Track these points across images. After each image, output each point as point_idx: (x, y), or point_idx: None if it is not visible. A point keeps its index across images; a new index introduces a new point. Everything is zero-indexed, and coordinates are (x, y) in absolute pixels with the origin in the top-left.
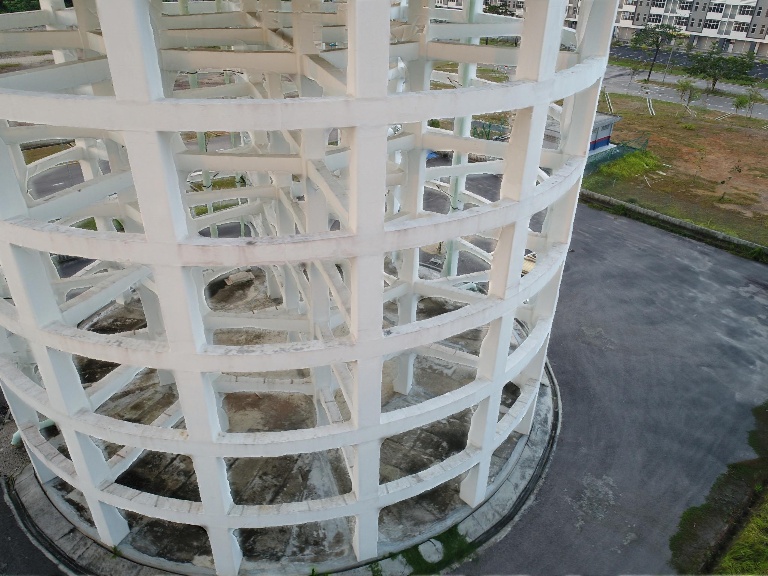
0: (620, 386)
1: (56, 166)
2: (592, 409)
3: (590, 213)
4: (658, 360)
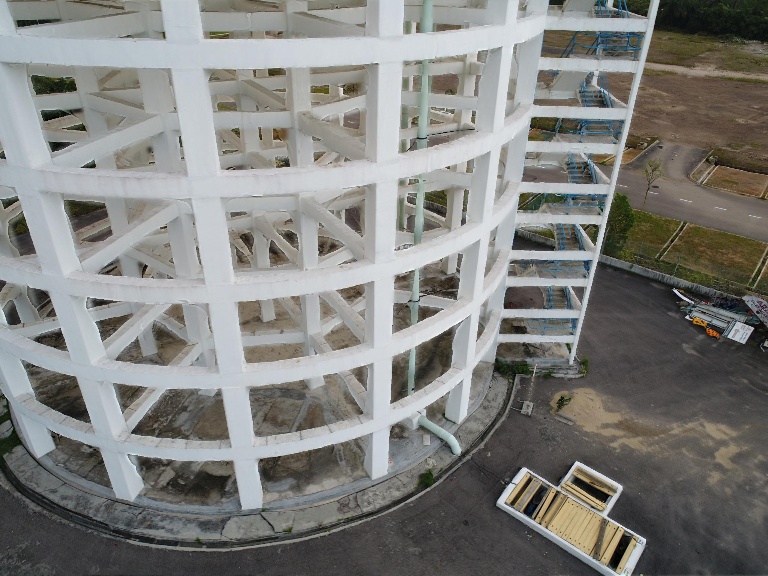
0: None
1: None
2: None
3: None
4: None
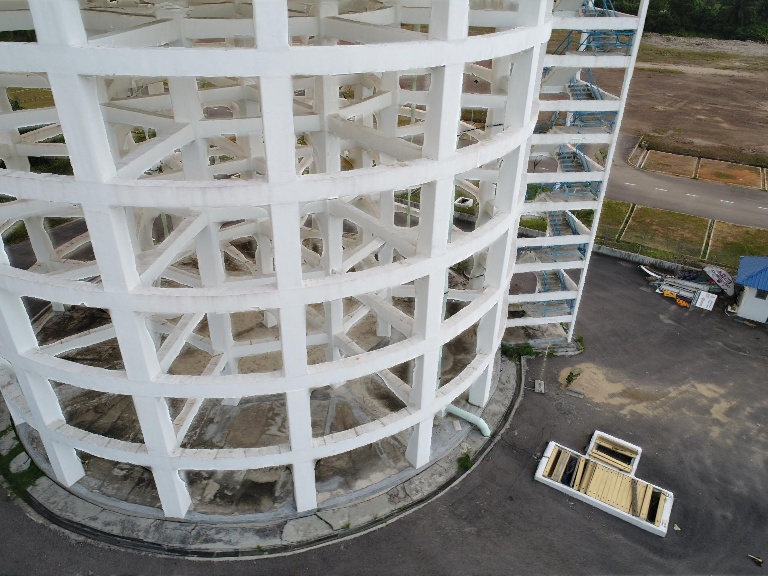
0: None
1: None
2: None
3: None
4: None
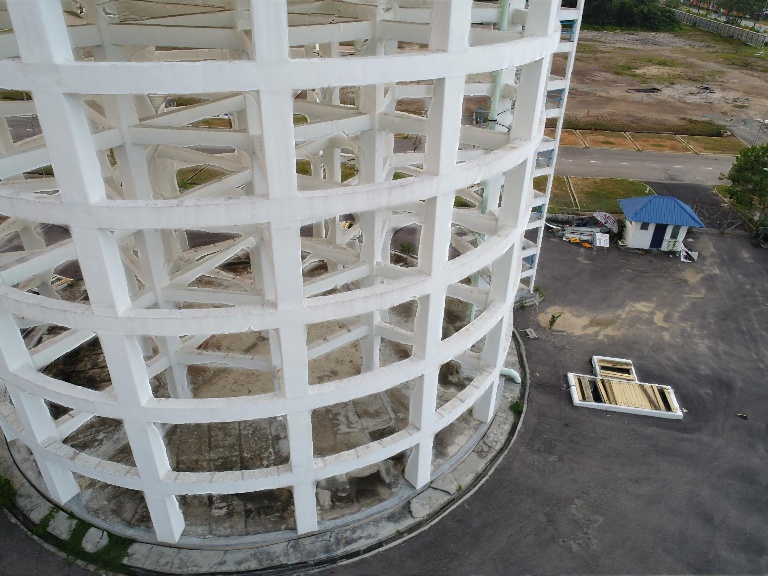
0: None
1: None
2: None
3: None
4: None
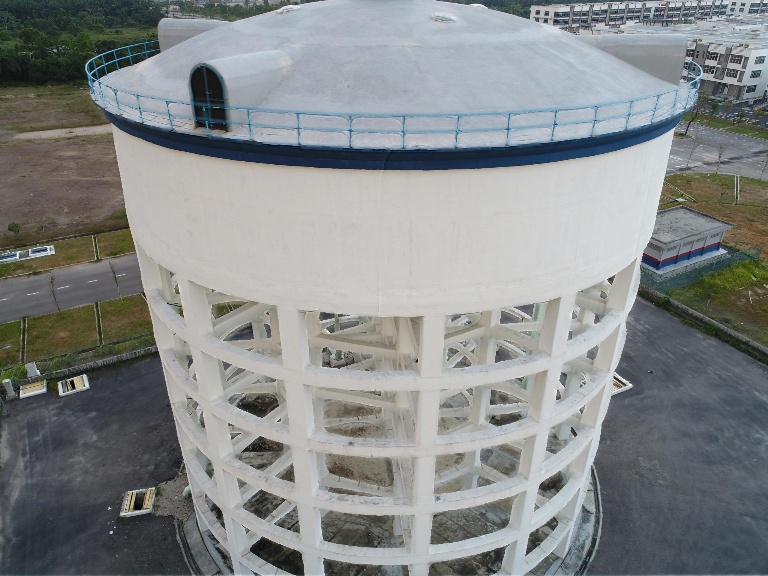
0: (659, 524)
1: None
2: (627, 542)
3: (680, 330)
4: (703, 503)
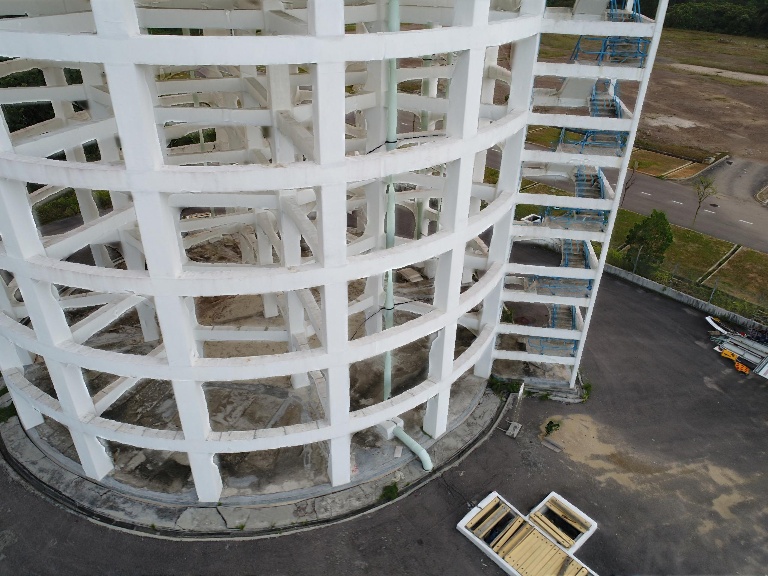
0: None
1: (628, 168)
2: (117, 574)
3: None
4: None
